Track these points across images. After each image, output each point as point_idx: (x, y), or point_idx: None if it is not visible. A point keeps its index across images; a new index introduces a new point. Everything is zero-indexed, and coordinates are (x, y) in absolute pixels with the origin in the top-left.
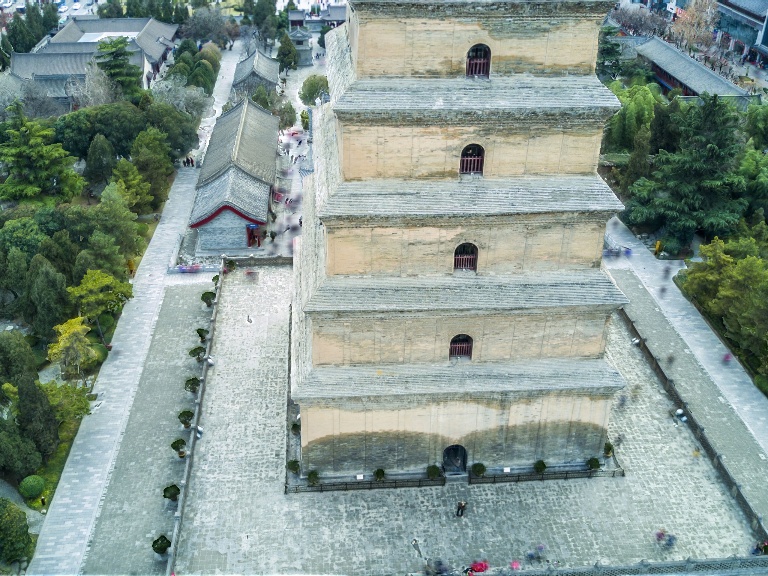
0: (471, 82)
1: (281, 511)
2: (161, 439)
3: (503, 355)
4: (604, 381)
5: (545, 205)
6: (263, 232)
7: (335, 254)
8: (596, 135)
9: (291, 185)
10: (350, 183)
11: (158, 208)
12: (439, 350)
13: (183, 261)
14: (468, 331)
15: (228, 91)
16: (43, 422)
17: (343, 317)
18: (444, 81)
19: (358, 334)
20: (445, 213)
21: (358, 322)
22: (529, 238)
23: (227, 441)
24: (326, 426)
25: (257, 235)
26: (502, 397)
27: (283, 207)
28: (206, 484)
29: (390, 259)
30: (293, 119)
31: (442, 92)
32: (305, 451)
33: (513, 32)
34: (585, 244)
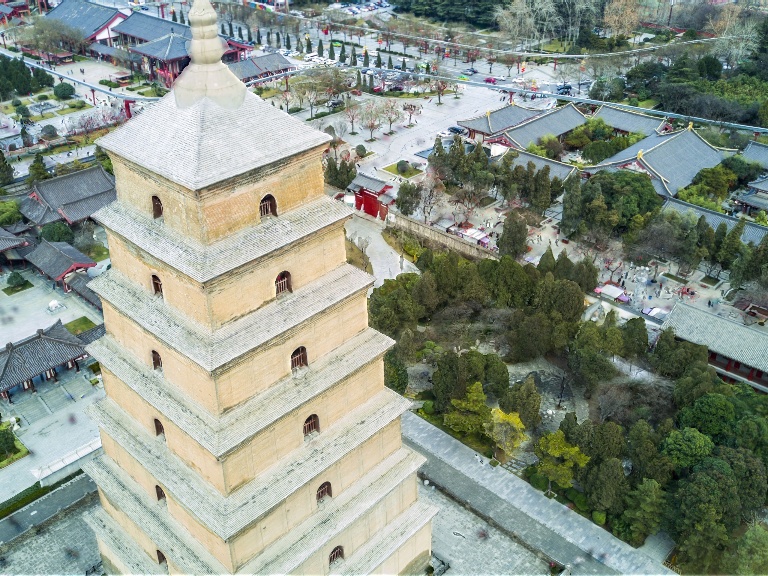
0: None
1: None
2: None
3: None
4: None
5: None
6: None
7: None
8: None
9: None
10: None
11: None
12: None
13: None
14: None
15: None
16: None
17: None
18: None
19: None
20: None
21: None
22: None
23: None
24: None
25: None
26: None
27: None
28: None
29: None
30: None
31: None
32: None
33: None
34: None
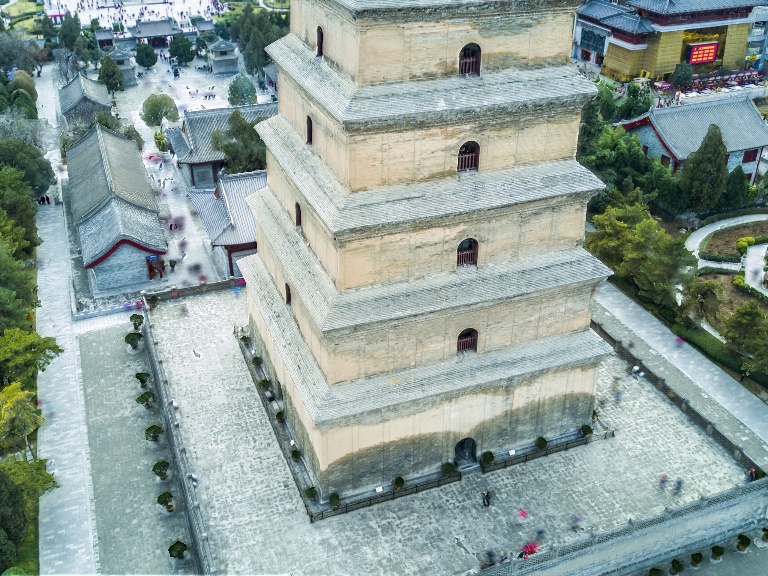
0: (465, 81)
1: (315, 541)
2: (139, 497)
3: (504, 342)
4: (595, 351)
5: (539, 192)
6: (160, 262)
7: (346, 268)
8: (575, 121)
9: (169, 210)
10: (357, 194)
11: (30, 253)
12: (448, 348)
13: (83, 305)
14: (473, 325)
15: (54, 120)
16: (10, 506)
17: (359, 331)
18: (440, 82)
19: (372, 346)
20: (452, 212)
21: (372, 333)
22: (523, 226)
23: (227, 483)
24: (345, 445)
25: (155, 266)
26: (507, 383)
27: (170, 234)
28: (224, 532)
29: (398, 265)
30: (141, 142)
31: (441, 93)
32: (325, 475)
33: (500, 29)
34: (570, 225)
